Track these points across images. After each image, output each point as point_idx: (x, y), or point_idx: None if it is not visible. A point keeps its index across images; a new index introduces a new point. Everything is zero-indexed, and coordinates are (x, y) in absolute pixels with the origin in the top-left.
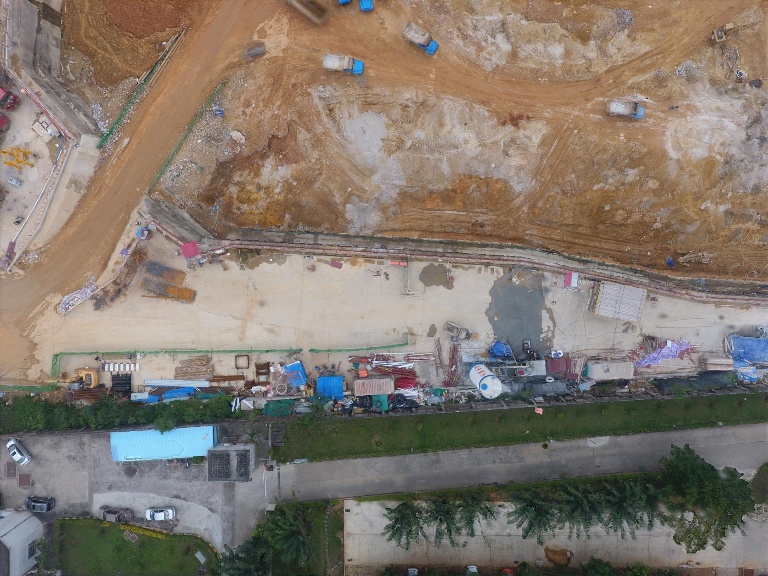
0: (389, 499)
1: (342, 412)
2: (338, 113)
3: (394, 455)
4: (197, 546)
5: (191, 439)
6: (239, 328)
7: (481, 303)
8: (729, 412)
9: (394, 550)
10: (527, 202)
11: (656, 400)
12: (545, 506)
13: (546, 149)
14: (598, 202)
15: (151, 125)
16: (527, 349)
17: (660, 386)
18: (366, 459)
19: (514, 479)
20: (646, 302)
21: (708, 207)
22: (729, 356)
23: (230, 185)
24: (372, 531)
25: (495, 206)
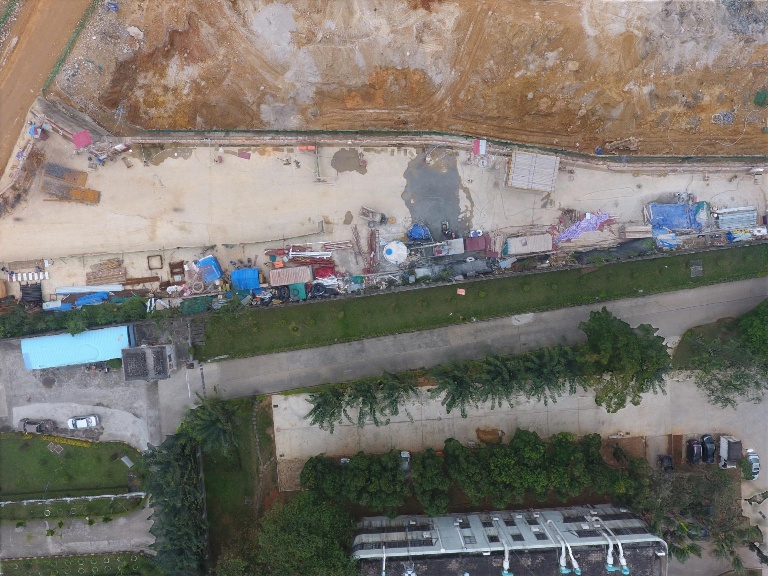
0: (316, 391)
1: (260, 305)
2: (242, 6)
3: (318, 346)
4: (125, 453)
5: (105, 341)
6: (149, 228)
7: (396, 186)
8: (651, 281)
9: (326, 442)
10: (449, 95)
11: (578, 273)
12: (466, 378)
13: (462, 34)
14: (520, 90)
15: (40, 22)
16: (445, 230)
17: (580, 258)
18: (290, 353)
19: (441, 363)
20: (563, 175)
21: (631, 89)
22: (649, 225)
23: (135, 89)
24: (302, 425)
25: (416, 101)
